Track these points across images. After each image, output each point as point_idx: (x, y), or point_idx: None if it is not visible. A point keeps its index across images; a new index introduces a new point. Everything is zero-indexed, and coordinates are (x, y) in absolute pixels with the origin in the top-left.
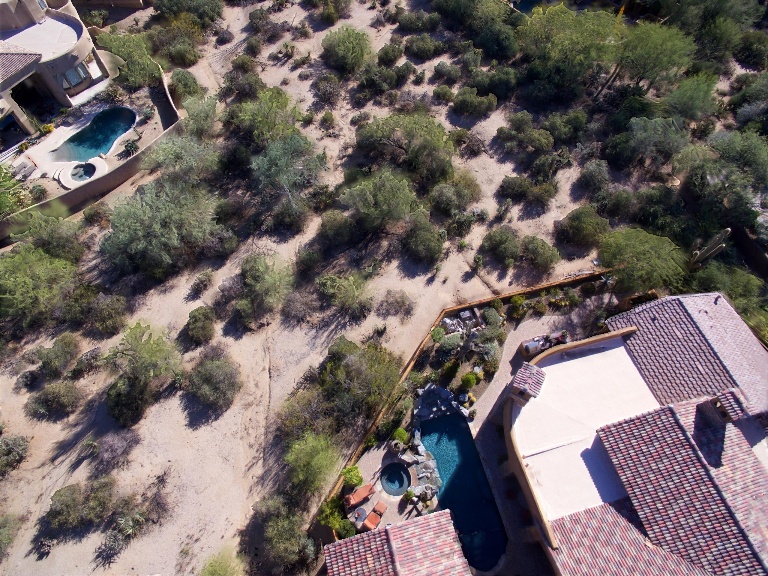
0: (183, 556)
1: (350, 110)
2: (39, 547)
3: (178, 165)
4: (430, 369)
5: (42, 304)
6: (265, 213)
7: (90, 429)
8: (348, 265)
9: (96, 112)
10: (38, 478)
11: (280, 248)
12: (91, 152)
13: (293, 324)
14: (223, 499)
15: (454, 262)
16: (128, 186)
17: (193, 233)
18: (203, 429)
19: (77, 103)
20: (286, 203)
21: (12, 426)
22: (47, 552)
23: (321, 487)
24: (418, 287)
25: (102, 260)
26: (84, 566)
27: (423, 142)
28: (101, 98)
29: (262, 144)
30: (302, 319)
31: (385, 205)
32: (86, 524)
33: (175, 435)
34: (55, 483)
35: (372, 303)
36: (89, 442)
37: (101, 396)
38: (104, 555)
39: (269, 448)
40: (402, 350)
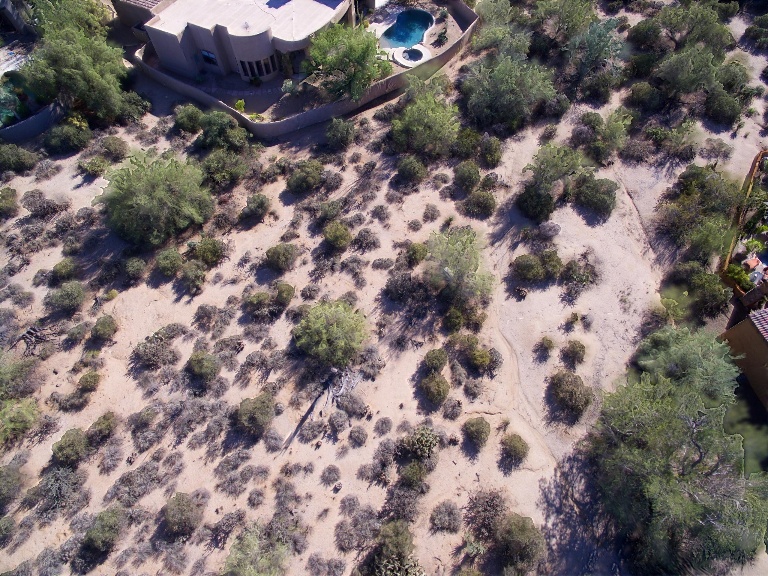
0: (623, 303)
1: (605, 16)
2: (515, 294)
3: (515, 42)
4: (763, 192)
5: (450, 137)
6: (573, 88)
7: (511, 225)
8: (660, 124)
9: (398, 13)
10: (487, 255)
11: (597, 112)
12: (402, 44)
13: (634, 163)
14: (635, 271)
15: (747, 123)
16: (448, 68)
17: (544, 92)
18: (598, 228)
19: (378, 6)
20: (601, 76)
21: (455, 220)
22: (524, 296)
23: (710, 264)
24: (726, 139)
25: (459, 117)
26: (556, 305)
27: (711, 28)
28: (395, 2)
29: (549, 38)
30: (641, 159)
31: (703, 70)
32: (544, 281)
33: (580, 230)
34: (503, 258)
35: (694, 149)
36: (527, 228)
37: (507, 206)
38: (566, 299)
39: (655, 241)
40: (735, 179)
